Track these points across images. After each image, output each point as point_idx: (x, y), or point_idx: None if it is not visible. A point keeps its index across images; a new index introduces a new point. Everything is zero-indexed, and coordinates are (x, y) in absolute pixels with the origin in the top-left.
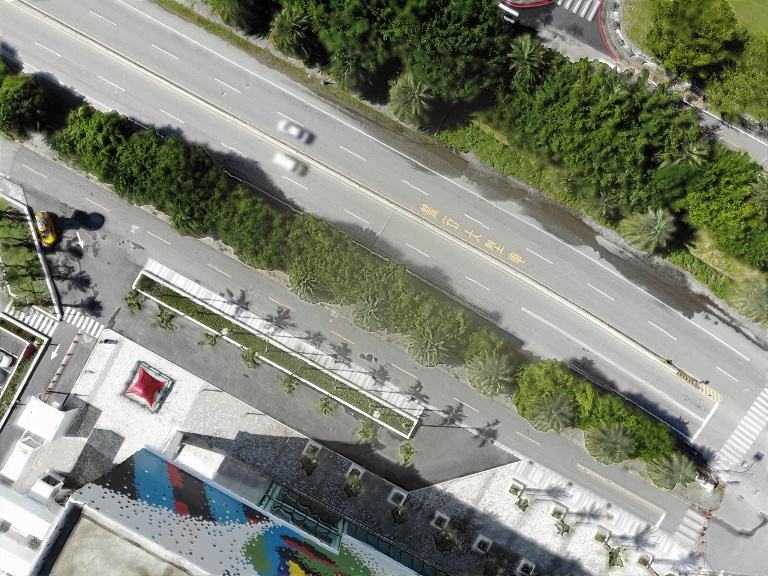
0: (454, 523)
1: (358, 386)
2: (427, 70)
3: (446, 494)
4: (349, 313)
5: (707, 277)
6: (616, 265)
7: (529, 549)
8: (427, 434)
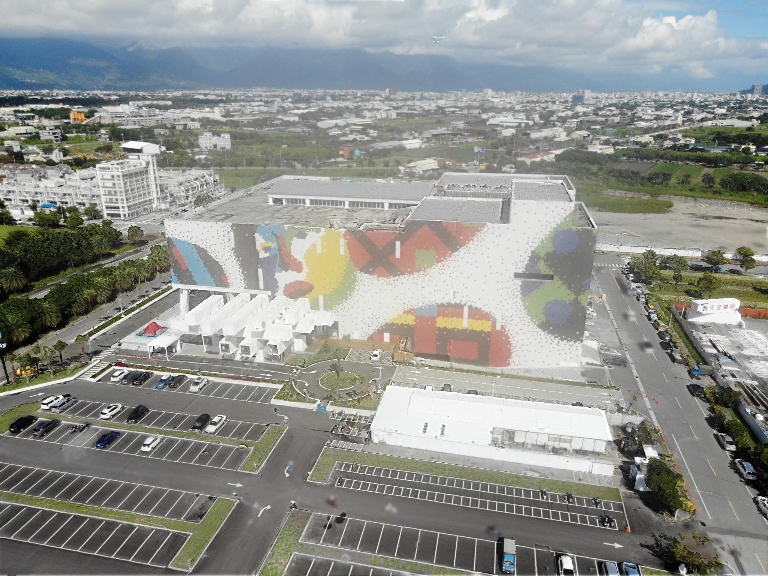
0: None
1: None
2: (3, 260)
3: None
4: None
5: (127, 249)
6: None
7: None
8: None
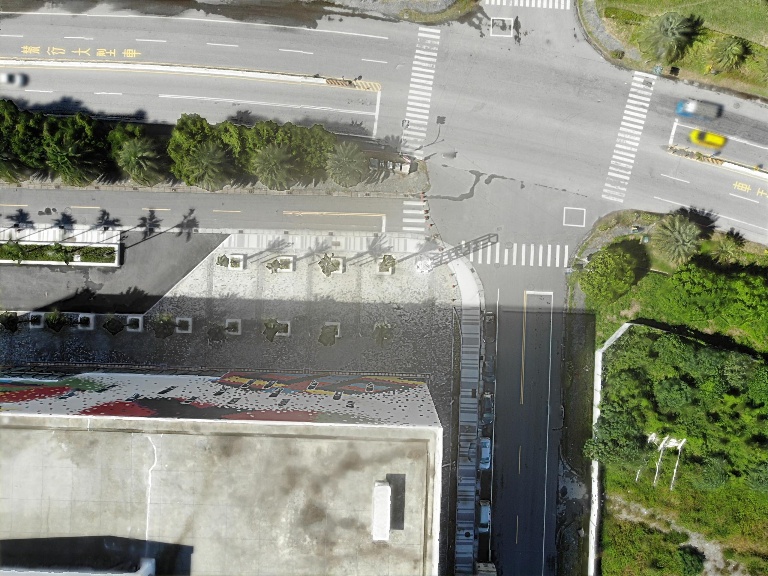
0: (199, 322)
1: (50, 242)
2: None
3: (178, 299)
4: None
5: None
6: (224, 14)
7: (278, 311)
8: (134, 254)
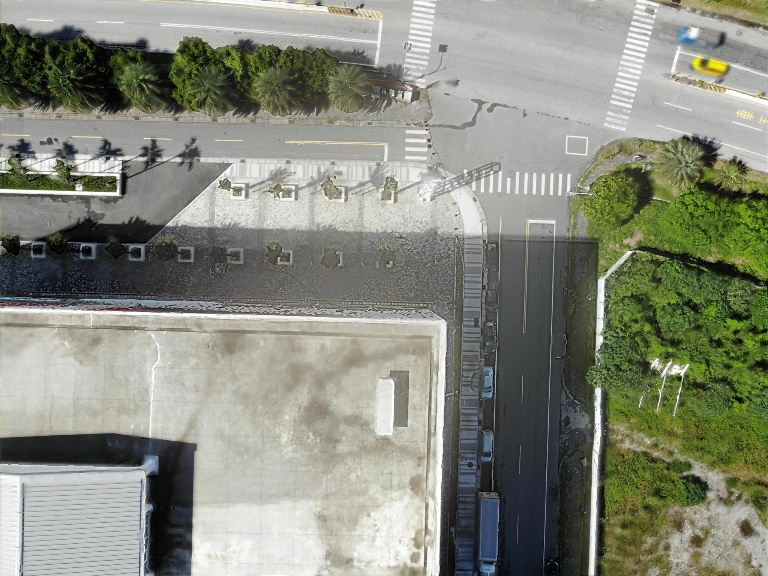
0: (201, 251)
1: (51, 172)
2: None
3: (180, 229)
4: (10, 110)
5: None
6: None
7: (280, 240)
8: (136, 184)
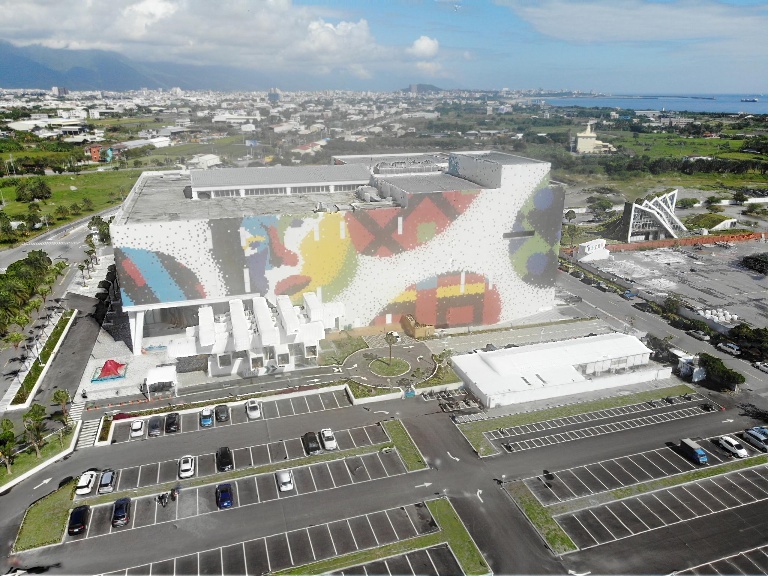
0: None
1: None
2: None
3: None
4: (1, 345)
5: None
6: None
7: None
8: None
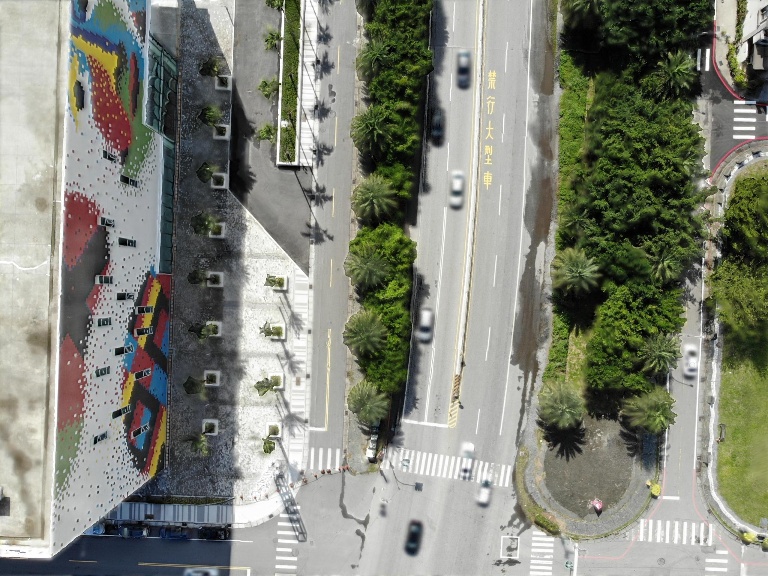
0: (221, 244)
1: (302, 95)
2: None
3: (244, 224)
4: None
5: (556, 357)
6: (526, 272)
7: (232, 323)
8: (290, 180)
